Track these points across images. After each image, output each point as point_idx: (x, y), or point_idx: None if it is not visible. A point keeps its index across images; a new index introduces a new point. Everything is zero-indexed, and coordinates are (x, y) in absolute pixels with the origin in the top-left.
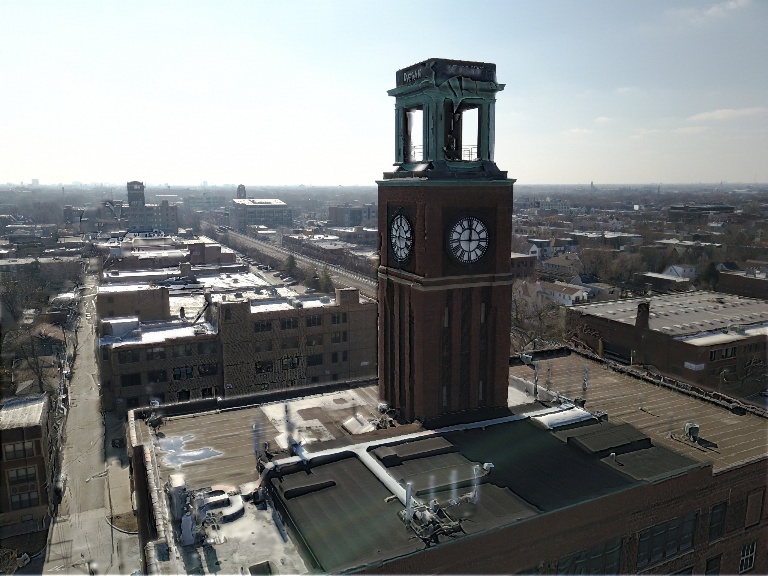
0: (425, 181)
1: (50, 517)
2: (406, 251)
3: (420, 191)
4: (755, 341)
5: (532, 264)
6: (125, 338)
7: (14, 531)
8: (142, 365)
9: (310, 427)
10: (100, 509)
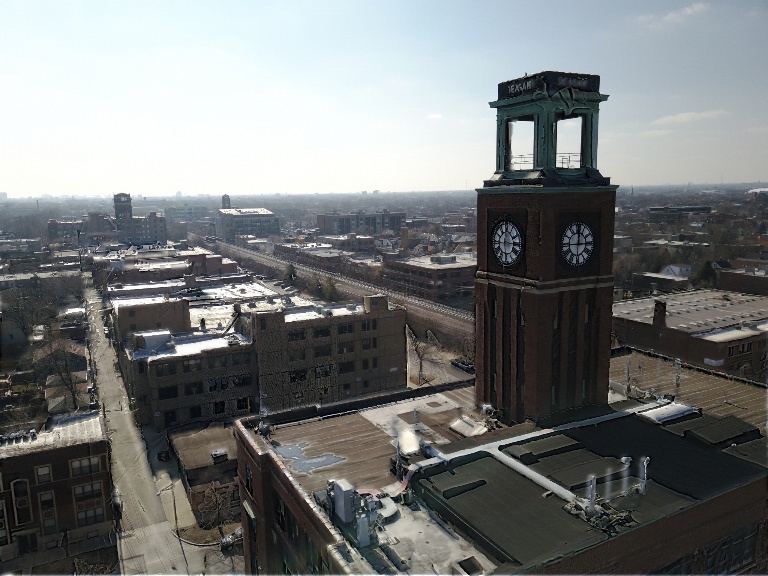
0: (540, 188)
1: (115, 533)
2: (513, 256)
3: (533, 198)
4: None
5: None
6: (159, 351)
7: (82, 548)
8: (179, 377)
9: (419, 430)
10: (163, 523)
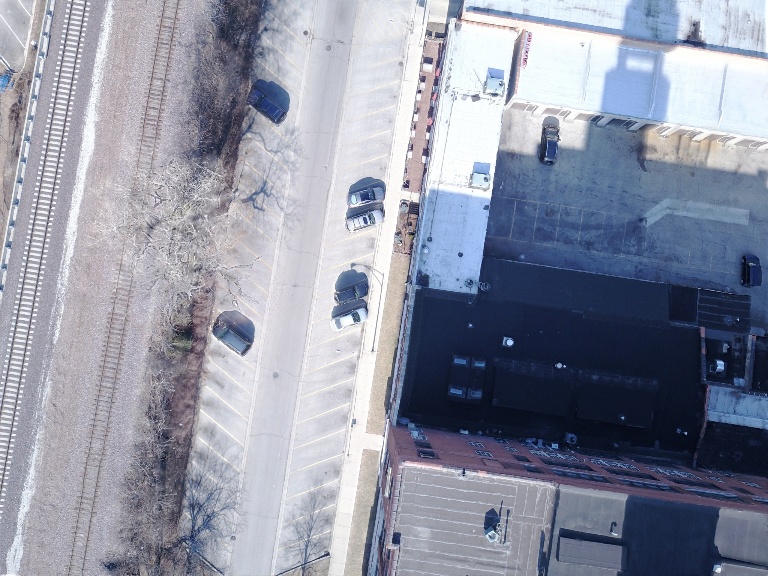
0: None
1: None
2: None
3: None
4: None
5: None
6: None
7: None
8: None
9: None
10: None
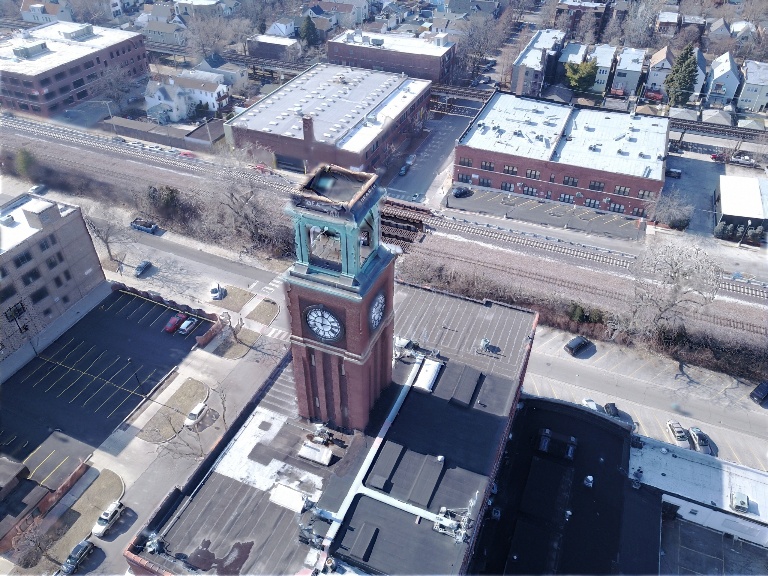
0: None
1: None
2: (332, 335)
3: (351, 303)
4: (386, 128)
5: (143, 43)
6: None
7: None
8: None
9: (279, 471)
10: None
